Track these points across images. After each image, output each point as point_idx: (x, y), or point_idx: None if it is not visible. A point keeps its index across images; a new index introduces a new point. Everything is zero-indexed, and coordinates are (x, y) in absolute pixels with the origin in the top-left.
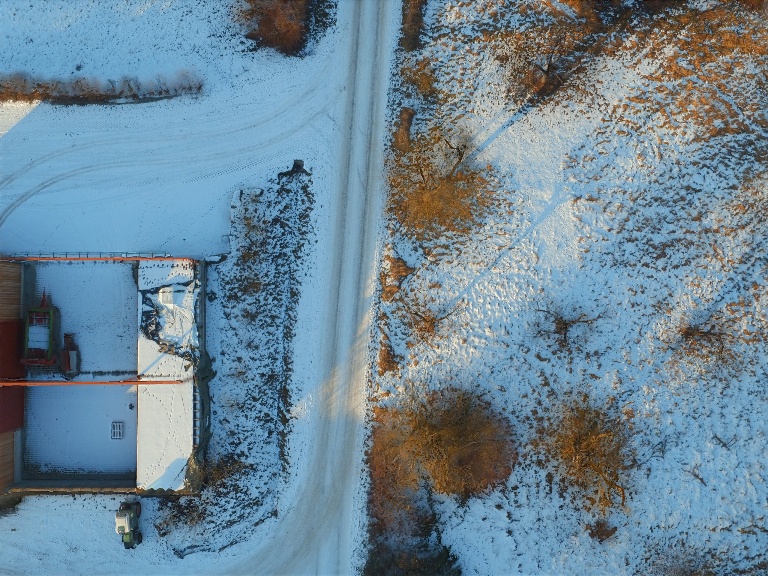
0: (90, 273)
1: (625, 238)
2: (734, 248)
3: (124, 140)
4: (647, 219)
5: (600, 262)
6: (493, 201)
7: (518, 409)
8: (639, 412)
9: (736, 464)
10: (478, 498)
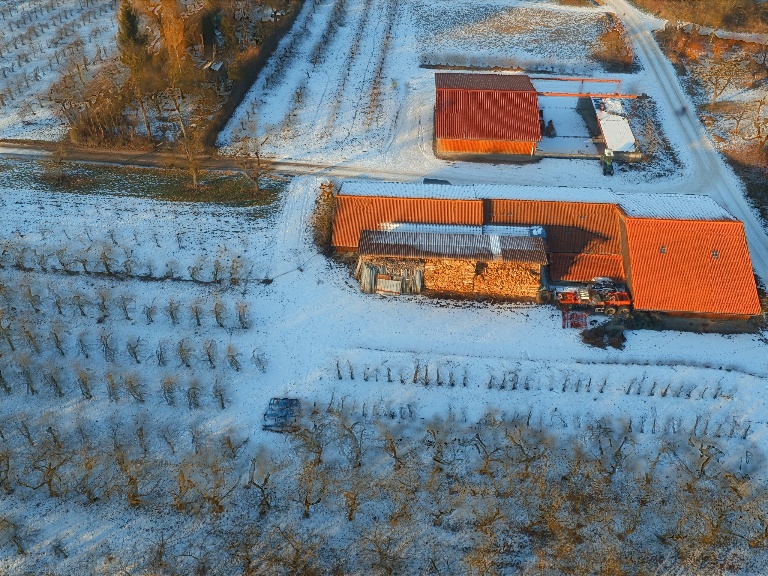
0: (554, 110)
1: None
2: None
3: None
4: None
5: None
6: (747, 107)
7: None
8: None
9: None
10: None
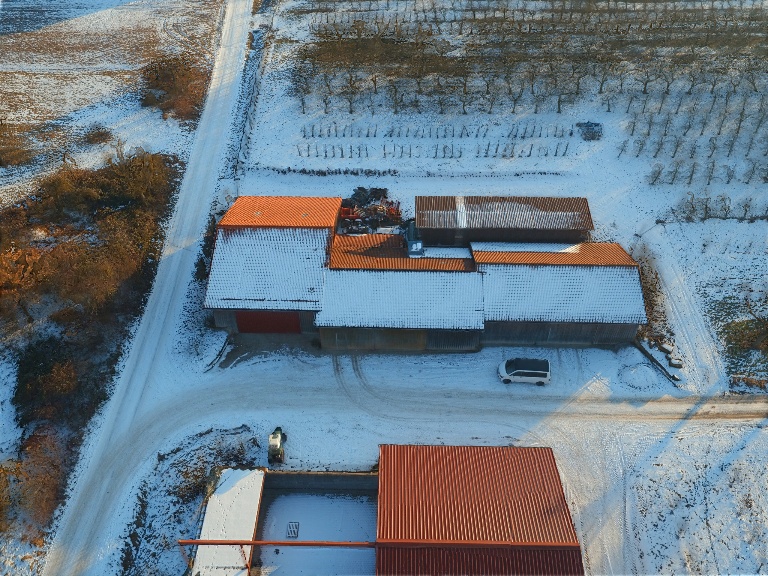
0: None
1: None
2: None
3: None
4: None
5: None
6: None
7: None
8: None
9: None
10: None
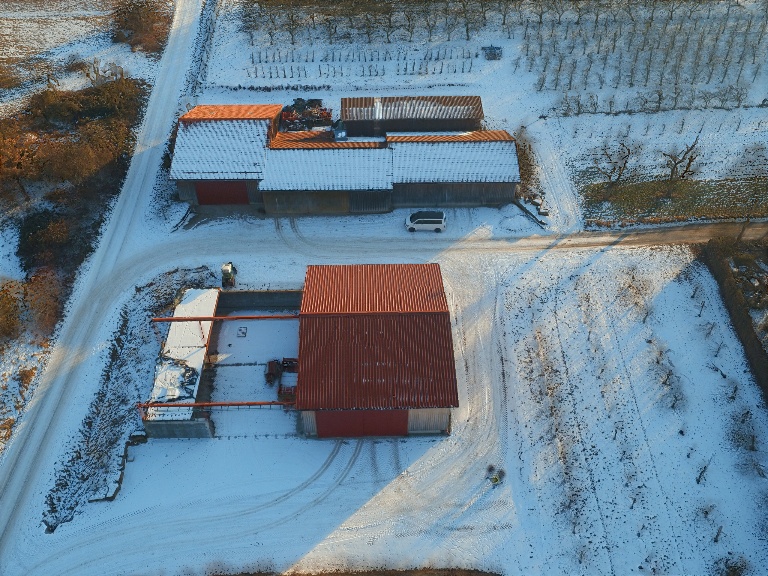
0: (251, 429)
1: None
2: None
3: (208, 541)
4: None
5: None
6: None
7: None
8: None
9: None
10: None
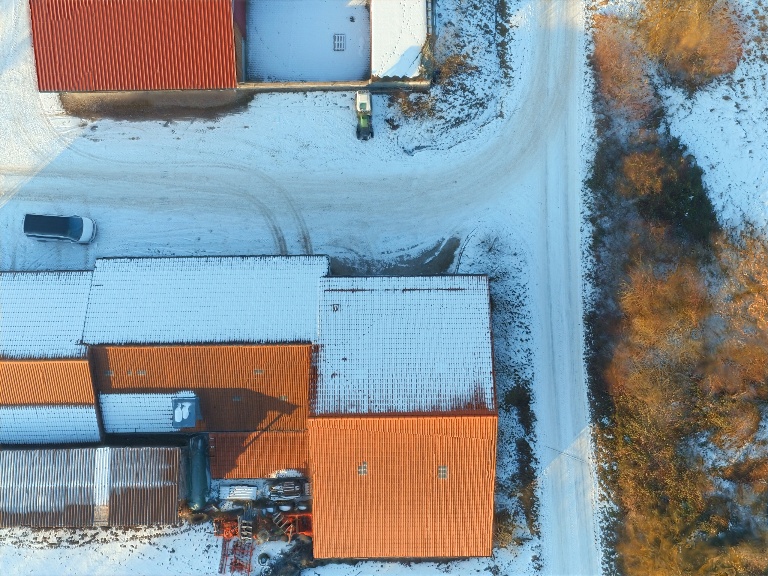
0: None
1: None
2: None
3: None
4: None
5: None
6: None
7: (739, 9)
8: None
9: None
10: (705, 91)
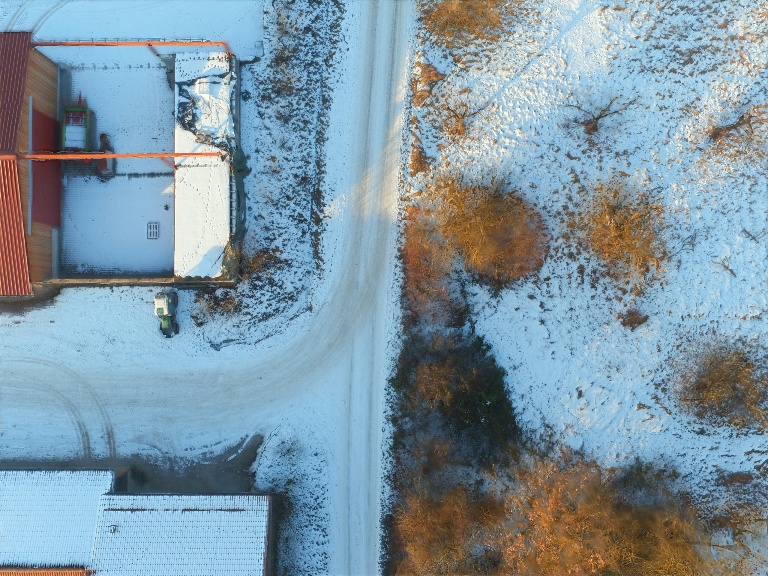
0: (125, 77)
1: (652, 45)
2: (760, 54)
3: None
4: (674, 27)
5: (628, 68)
6: (522, 10)
7: (549, 204)
8: (669, 208)
9: (765, 255)
10: (511, 289)
